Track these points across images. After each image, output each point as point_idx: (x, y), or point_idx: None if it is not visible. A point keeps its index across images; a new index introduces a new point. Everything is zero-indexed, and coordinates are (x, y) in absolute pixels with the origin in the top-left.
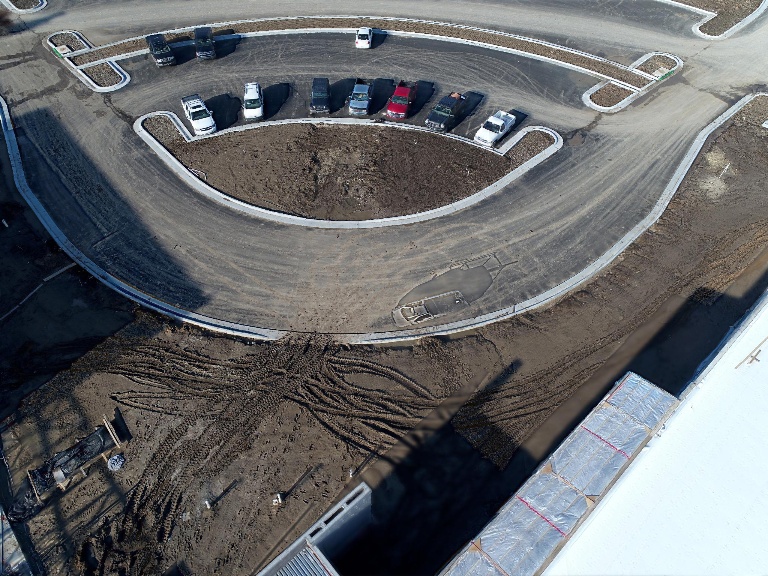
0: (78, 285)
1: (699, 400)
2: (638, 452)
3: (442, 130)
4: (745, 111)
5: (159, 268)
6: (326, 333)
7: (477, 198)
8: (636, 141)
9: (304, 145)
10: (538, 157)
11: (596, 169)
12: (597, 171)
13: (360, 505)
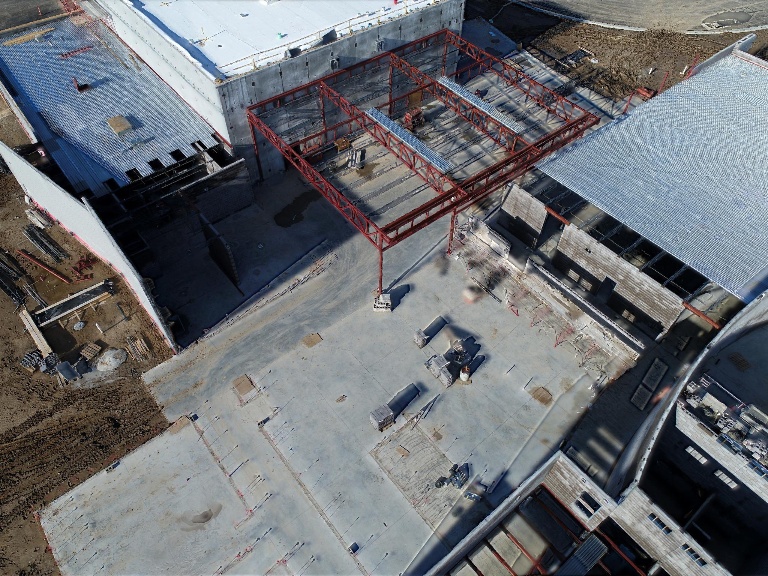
0: (523, 8)
1: None
2: None
3: None
4: None
5: (559, 6)
6: (669, 29)
7: None
8: None
9: None
10: None
11: None
12: None
13: None
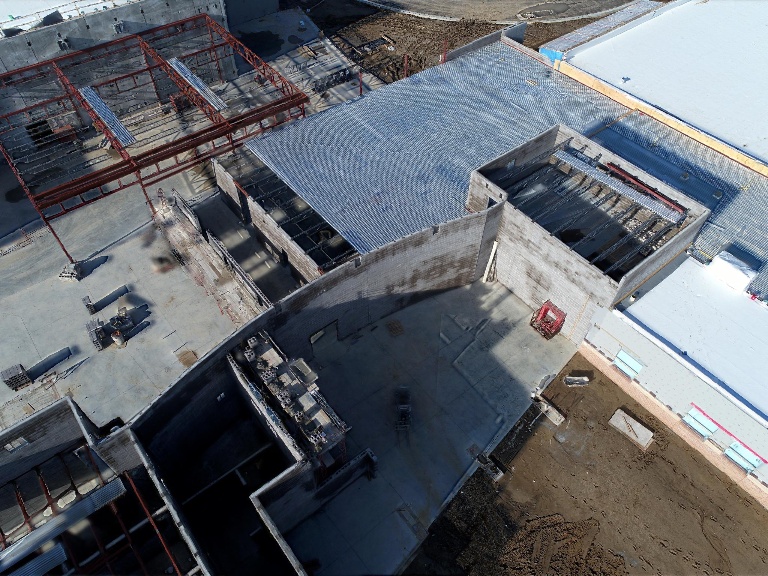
0: None
1: (676, 11)
2: (645, 14)
3: None
4: None
5: None
6: (482, 20)
7: None
8: None
9: None
10: None
11: None
12: None
13: (521, 30)
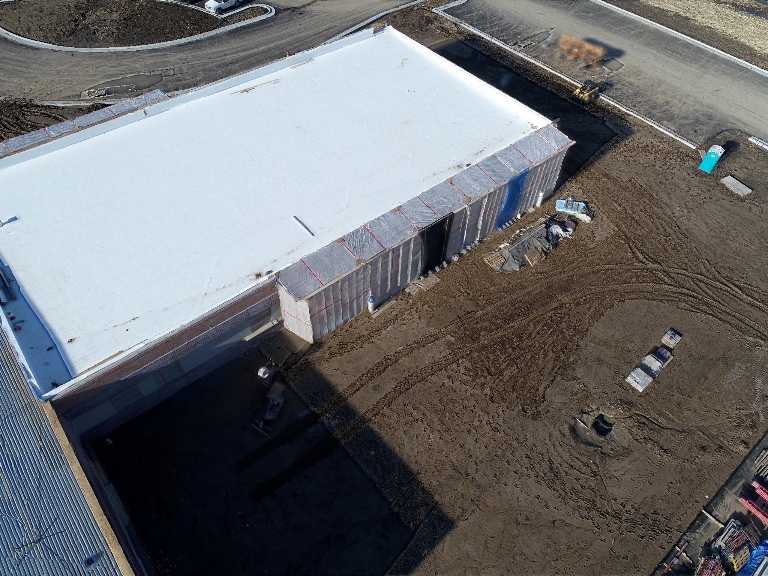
0: None
1: (193, 105)
2: (124, 114)
3: (184, 1)
4: (428, 2)
5: None
6: (30, 99)
7: (185, 40)
8: (329, 15)
9: (81, 7)
10: (248, 21)
11: (285, 29)
12: (285, 30)
13: None
